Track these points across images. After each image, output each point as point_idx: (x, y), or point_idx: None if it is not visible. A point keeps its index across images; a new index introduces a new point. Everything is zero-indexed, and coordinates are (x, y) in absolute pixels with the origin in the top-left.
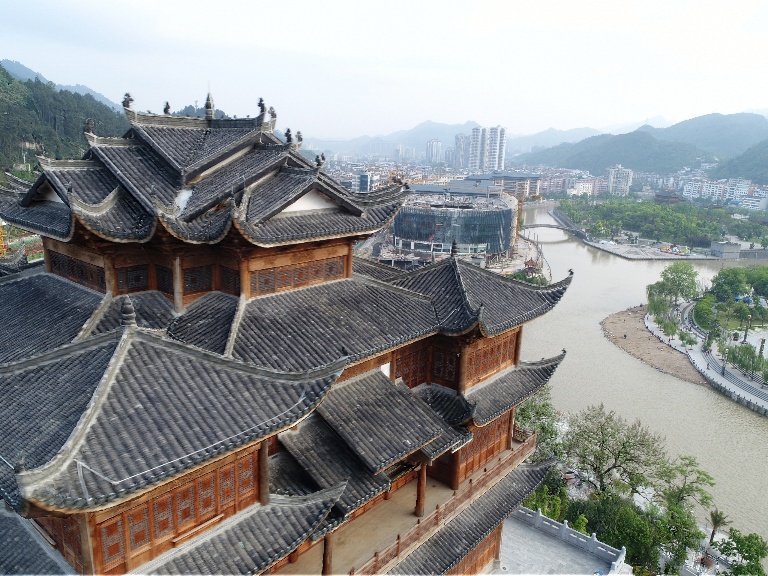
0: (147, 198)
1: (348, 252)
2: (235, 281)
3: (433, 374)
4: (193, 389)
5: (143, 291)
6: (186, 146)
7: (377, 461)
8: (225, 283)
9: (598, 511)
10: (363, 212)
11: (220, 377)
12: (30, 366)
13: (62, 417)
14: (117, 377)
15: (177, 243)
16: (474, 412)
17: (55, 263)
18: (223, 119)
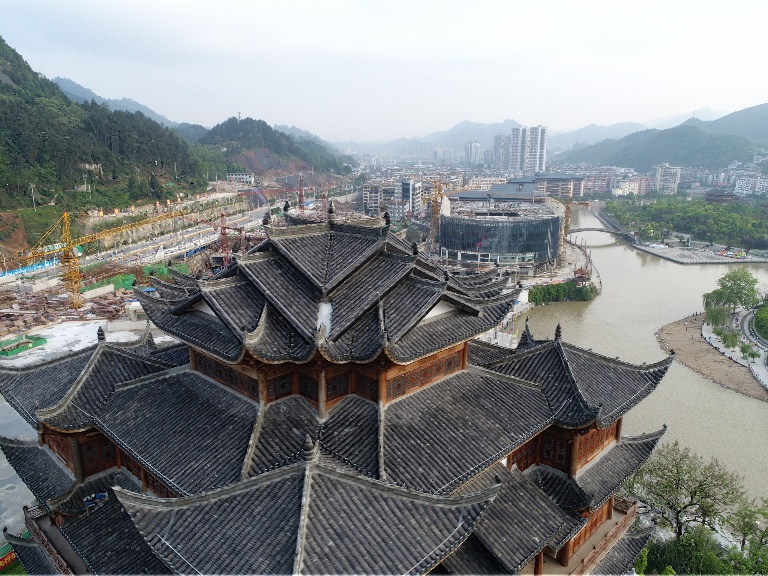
0: (296, 318)
1: (464, 346)
2: (372, 388)
3: (542, 456)
4: (369, 520)
5: (287, 396)
6: (318, 257)
7: (513, 563)
8: (361, 388)
9: (678, 554)
10: (480, 312)
11: (388, 505)
12: (223, 495)
13: (270, 556)
14: (309, 515)
15: (327, 363)
16: (591, 503)
17: (200, 363)
18: (346, 225)
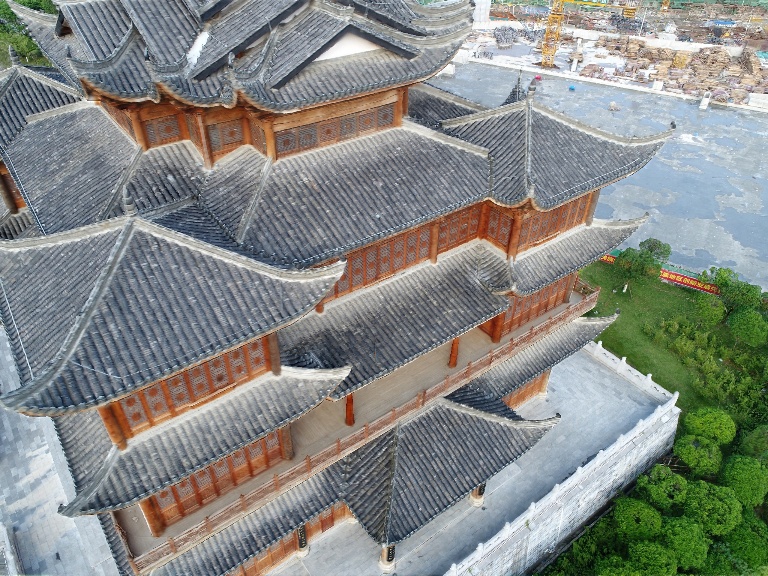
0: None
1: None
2: None
3: None
4: None
5: None
6: None
7: None
8: None
9: None
10: None
11: None
12: None
13: None
14: None
15: None
16: None
17: None
18: None
